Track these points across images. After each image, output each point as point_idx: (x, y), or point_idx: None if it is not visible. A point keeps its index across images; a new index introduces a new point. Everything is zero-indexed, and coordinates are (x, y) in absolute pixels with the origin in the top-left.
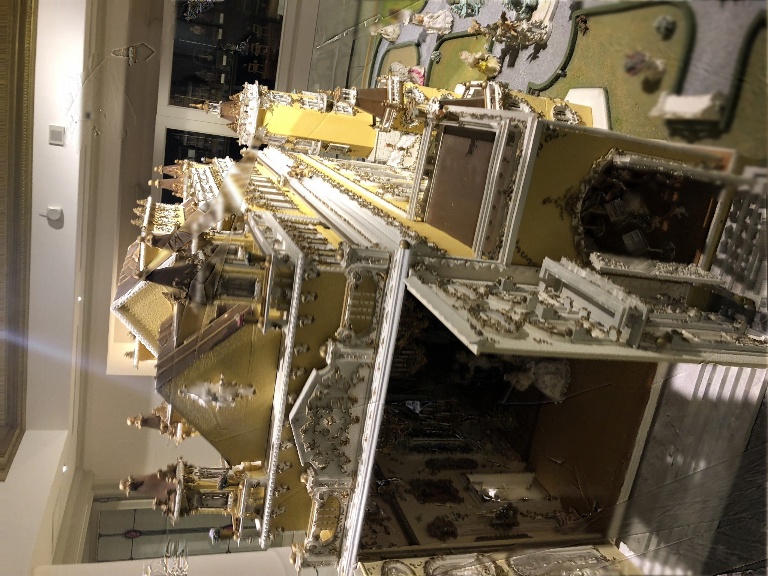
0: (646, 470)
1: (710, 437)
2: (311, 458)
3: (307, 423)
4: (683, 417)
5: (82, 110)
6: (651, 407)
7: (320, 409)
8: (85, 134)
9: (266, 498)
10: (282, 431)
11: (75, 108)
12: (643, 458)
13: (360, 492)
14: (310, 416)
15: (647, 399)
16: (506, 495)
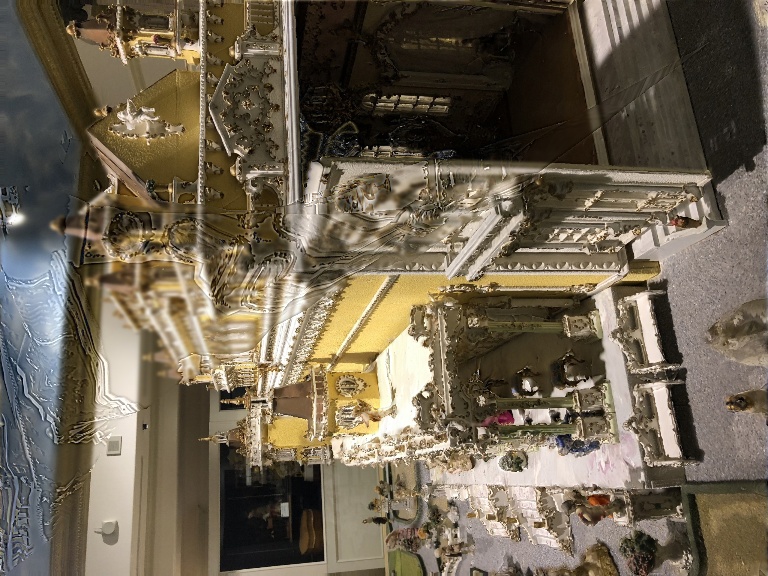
0: (616, 154)
1: (644, 64)
2: (235, 141)
3: (226, 107)
4: (614, 70)
5: (74, 130)
6: (590, 95)
7: (237, 94)
8: (79, 160)
9: (197, 197)
10: (208, 137)
11: (68, 125)
12: (609, 149)
13: (291, 164)
14: (227, 100)
15: (582, 90)
16: (537, 368)
